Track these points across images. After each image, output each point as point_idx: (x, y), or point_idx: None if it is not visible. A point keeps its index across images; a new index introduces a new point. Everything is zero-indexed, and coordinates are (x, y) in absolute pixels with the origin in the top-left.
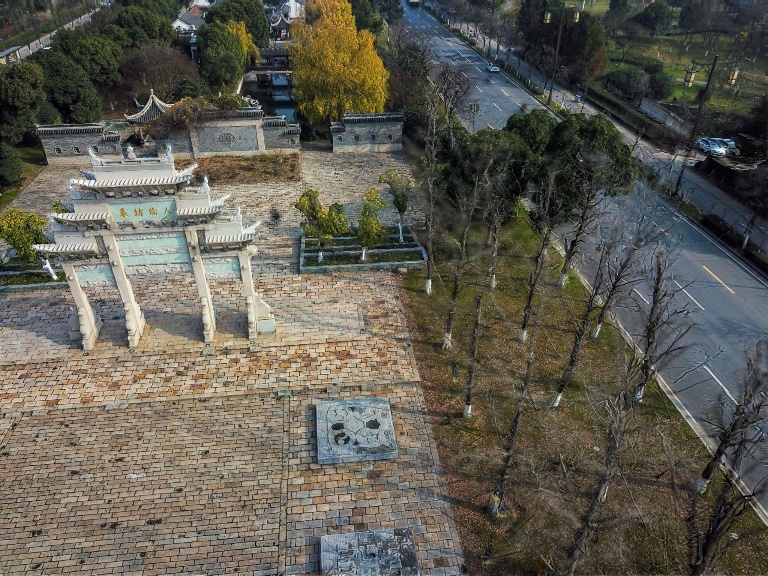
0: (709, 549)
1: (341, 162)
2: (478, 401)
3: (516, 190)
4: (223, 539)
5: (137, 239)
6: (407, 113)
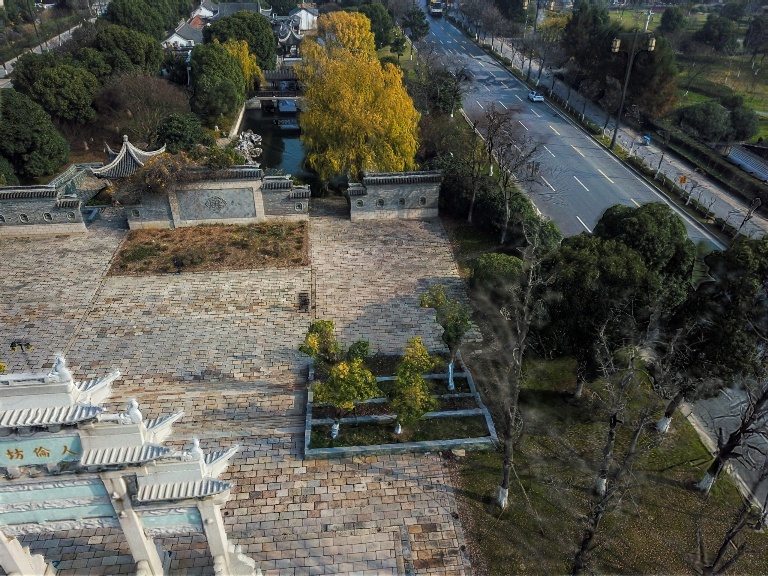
0: None
1: (361, 235)
2: None
3: (635, 340)
4: None
5: (18, 490)
6: (444, 168)
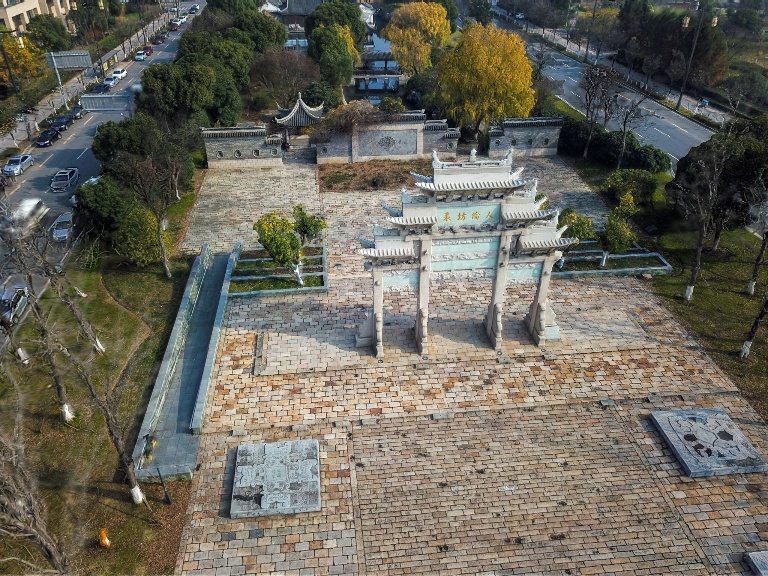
0: None
1: None
2: None
3: None
4: (641, 555)
5: (451, 244)
6: None
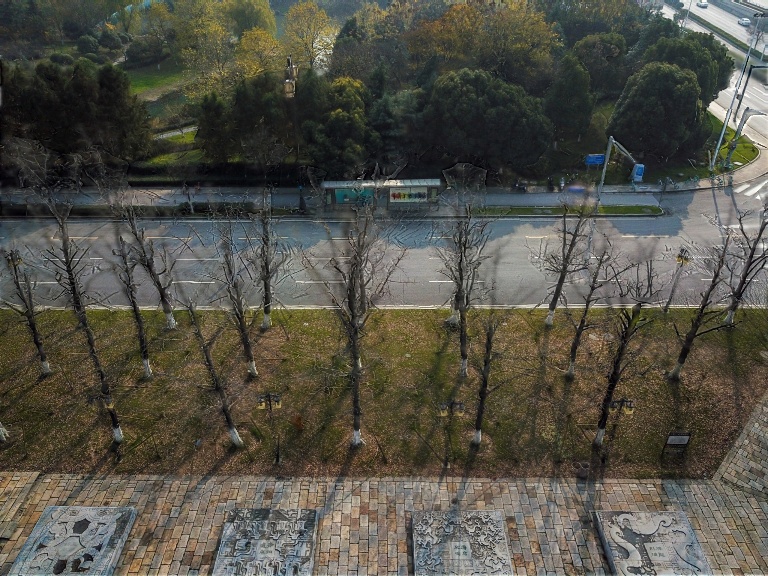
0: (354, 303)
1: None
2: (106, 427)
3: None
4: None
5: None
6: None
